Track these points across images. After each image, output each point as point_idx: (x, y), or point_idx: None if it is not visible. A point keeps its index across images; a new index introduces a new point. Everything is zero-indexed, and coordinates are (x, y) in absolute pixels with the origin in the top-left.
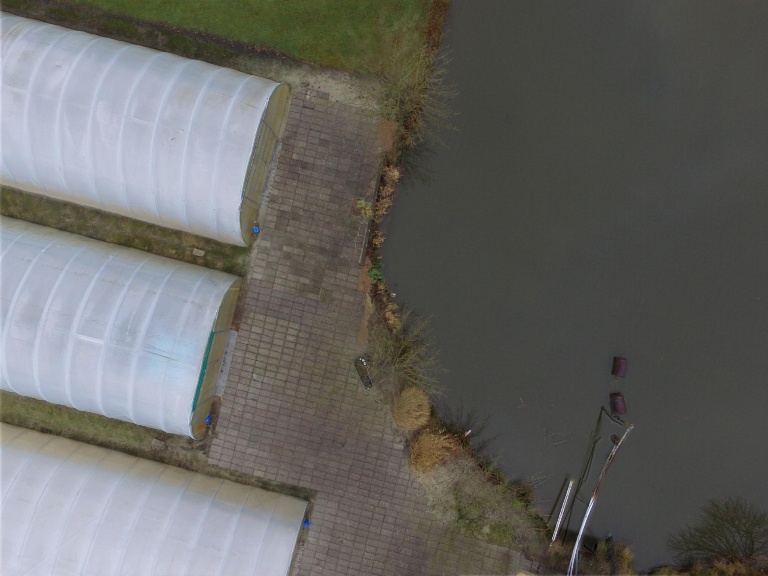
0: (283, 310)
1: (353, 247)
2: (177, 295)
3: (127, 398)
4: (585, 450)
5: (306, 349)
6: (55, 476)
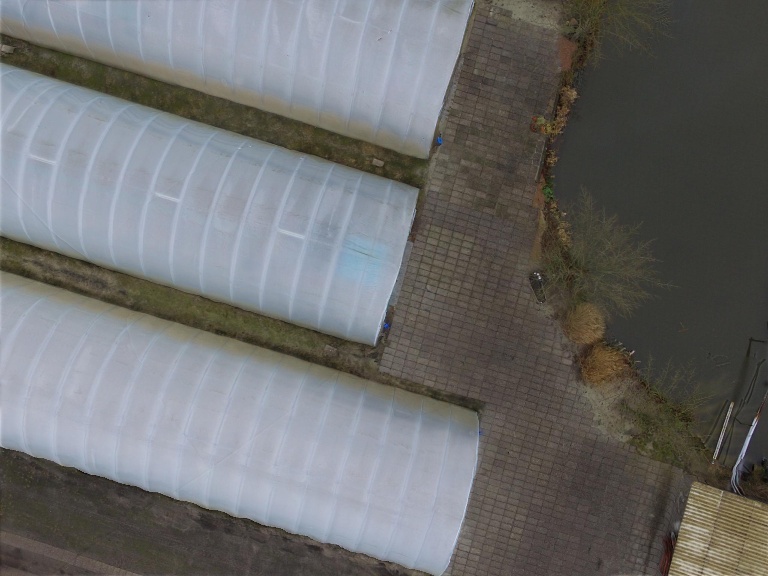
0: (459, 223)
1: (530, 164)
2: (372, 196)
3: (321, 295)
4: (749, 372)
5: (480, 262)
6: (243, 371)
